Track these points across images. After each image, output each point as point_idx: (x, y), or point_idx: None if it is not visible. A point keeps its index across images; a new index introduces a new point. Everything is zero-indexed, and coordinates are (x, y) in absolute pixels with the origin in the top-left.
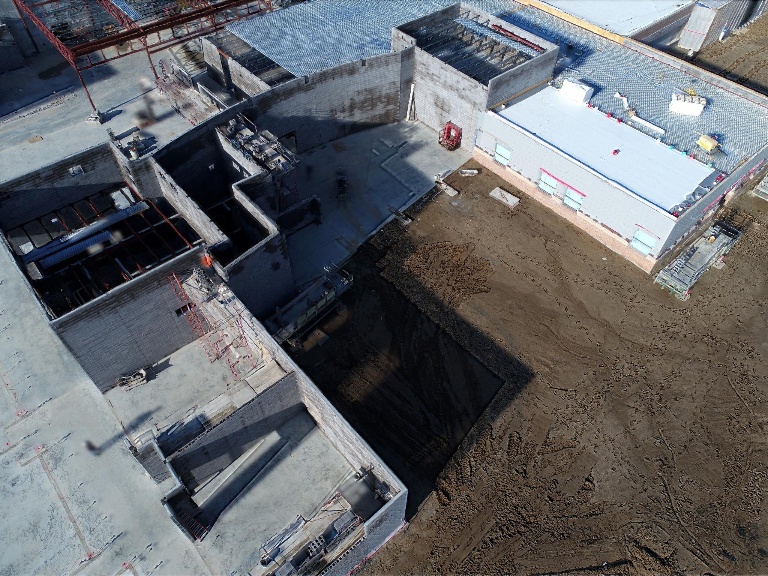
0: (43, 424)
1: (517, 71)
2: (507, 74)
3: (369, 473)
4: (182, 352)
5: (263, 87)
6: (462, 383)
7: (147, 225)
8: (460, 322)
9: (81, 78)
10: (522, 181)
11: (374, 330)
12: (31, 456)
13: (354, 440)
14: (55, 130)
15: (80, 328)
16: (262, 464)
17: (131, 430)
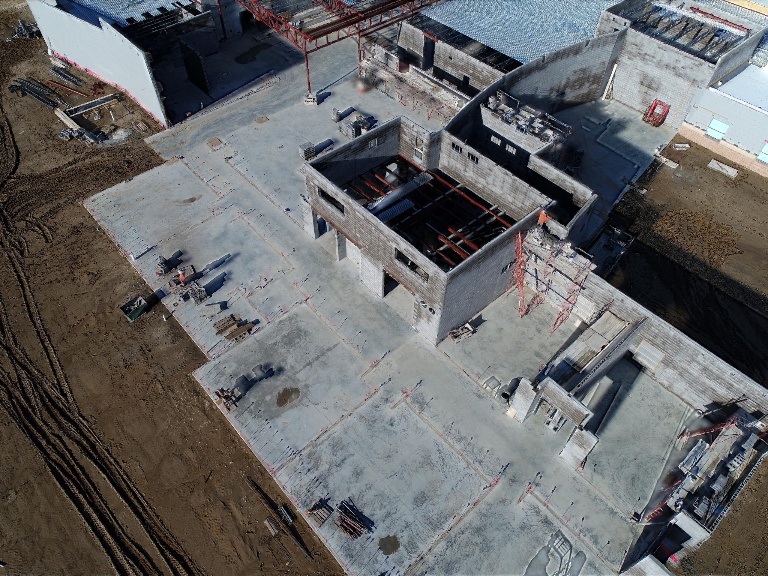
0: (393, 373)
1: (737, 50)
2: (731, 52)
3: (728, 406)
4: (490, 309)
5: (482, 68)
6: (753, 333)
7: (438, 194)
8: (728, 280)
9: (307, 61)
10: (738, 153)
11: (653, 288)
12: (396, 400)
13: (726, 375)
14: (276, 111)
15: (457, 281)
16: (607, 404)
17: (476, 377)
